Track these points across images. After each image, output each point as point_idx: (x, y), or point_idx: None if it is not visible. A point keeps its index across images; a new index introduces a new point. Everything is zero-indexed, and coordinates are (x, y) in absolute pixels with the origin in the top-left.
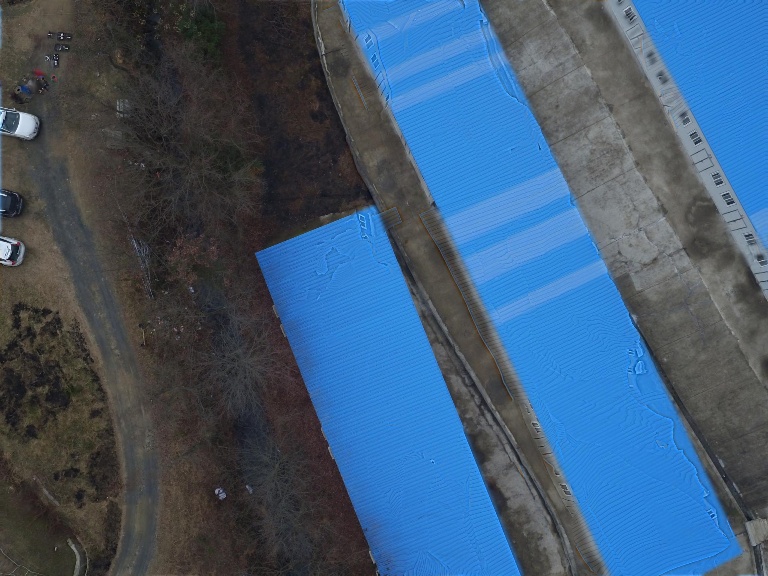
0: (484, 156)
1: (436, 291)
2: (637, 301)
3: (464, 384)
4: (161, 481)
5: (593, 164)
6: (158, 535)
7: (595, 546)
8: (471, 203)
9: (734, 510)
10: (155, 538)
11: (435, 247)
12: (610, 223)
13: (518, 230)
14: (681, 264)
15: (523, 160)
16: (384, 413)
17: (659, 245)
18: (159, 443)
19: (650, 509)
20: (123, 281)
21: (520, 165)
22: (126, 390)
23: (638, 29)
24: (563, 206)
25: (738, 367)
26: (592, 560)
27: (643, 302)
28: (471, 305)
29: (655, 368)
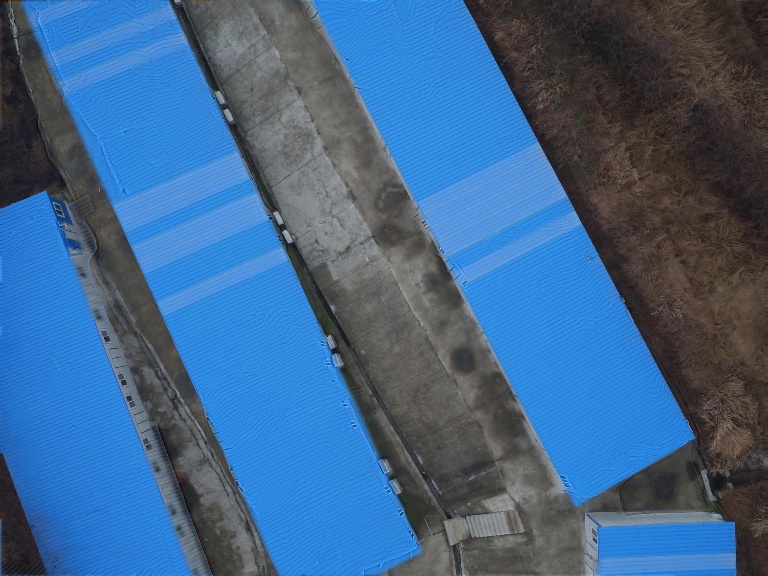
0: (170, 141)
1: (124, 281)
2: (335, 291)
3: (157, 377)
4: None
5: (287, 149)
6: None
7: (283, 545)
8: (157, 190)
9: (433, 508)
10: None
11: (123, 236)
12: (306, 210)
13: (195, 217)
14: (371, 252)
15: (137, 143)
16: None
17: (351, 233)
18: None
19: None
20: None
21: (133, 148)
22: None
23: (312, 7)
24: (242, 192)
25: (429, 359)
26: (278, 559)
27: (340, 292)
28: (157, 295)
29: (353, 361)
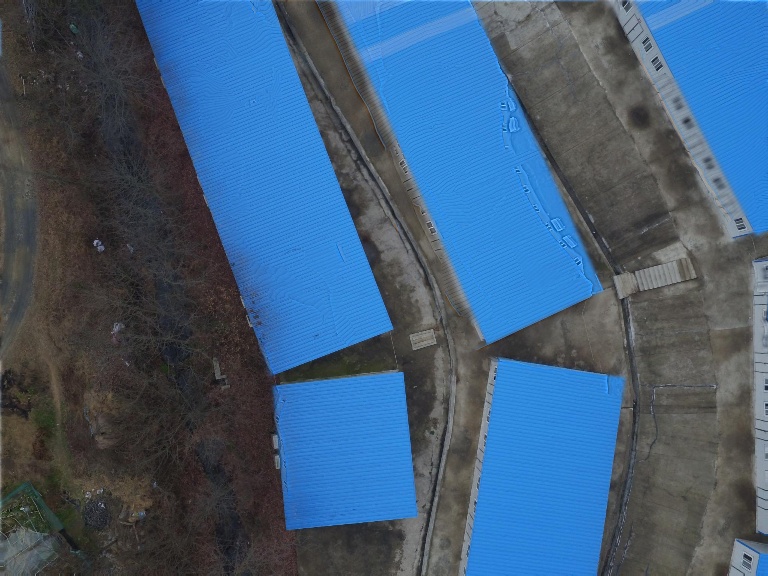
0: None
1: (313, 44)
2: (512, 60)
3: (341, 139)
4: (39, 230)
5: None
6: (35, 283)
7: (464, 294)
8: None
9: (603, 265)
10: (32, 286)
11: (313, 1)
12: None
13: None
14: (552, 18)
15: None
16: (226, 90)
17: (532, 1)
18: (38, 192)
19: (521, 263)
20: (5, 32)
21: None
22: (6, 140)
23: None
24: None
25: (606, 118)
26: (460, 306)
27: (518, 61)
28: (346, 56)
29: (529, 126)
